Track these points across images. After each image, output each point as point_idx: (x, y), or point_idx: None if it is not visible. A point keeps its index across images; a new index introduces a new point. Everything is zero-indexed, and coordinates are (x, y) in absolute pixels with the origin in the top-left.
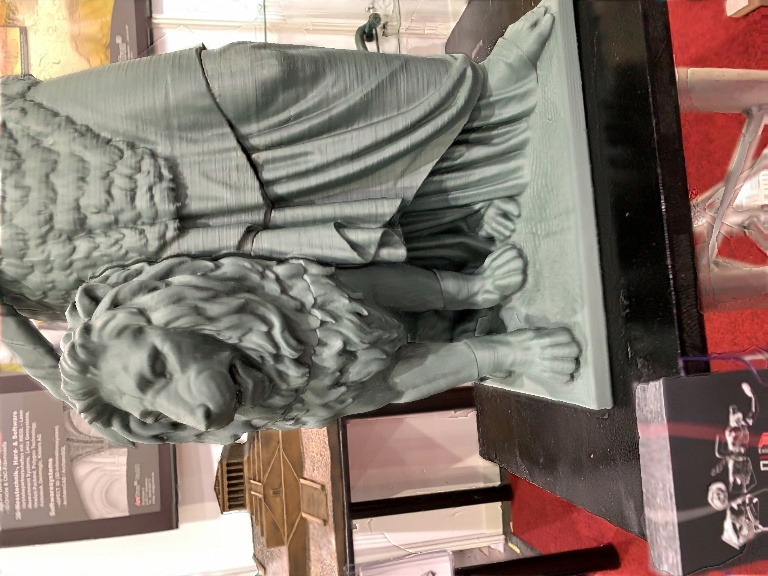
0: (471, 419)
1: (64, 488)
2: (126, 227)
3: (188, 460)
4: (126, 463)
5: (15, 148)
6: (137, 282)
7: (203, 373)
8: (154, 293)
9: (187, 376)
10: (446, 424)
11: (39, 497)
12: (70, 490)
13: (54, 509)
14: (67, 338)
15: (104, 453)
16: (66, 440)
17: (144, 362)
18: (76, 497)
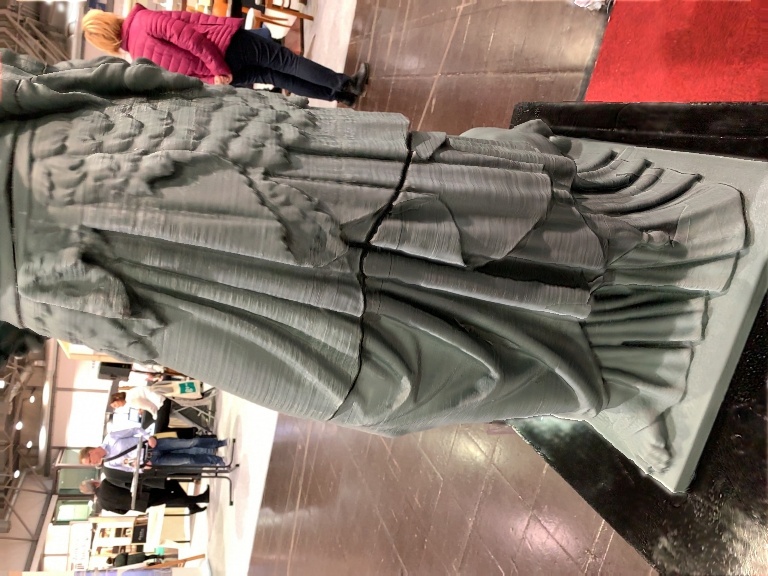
0: None
1: None
2: None
3: None
4: None
5: None
6: None
7: None
8: None
9: None
10: None
11: None
12: None
13: None
14: None
15: None
16: None
17: None
18: None
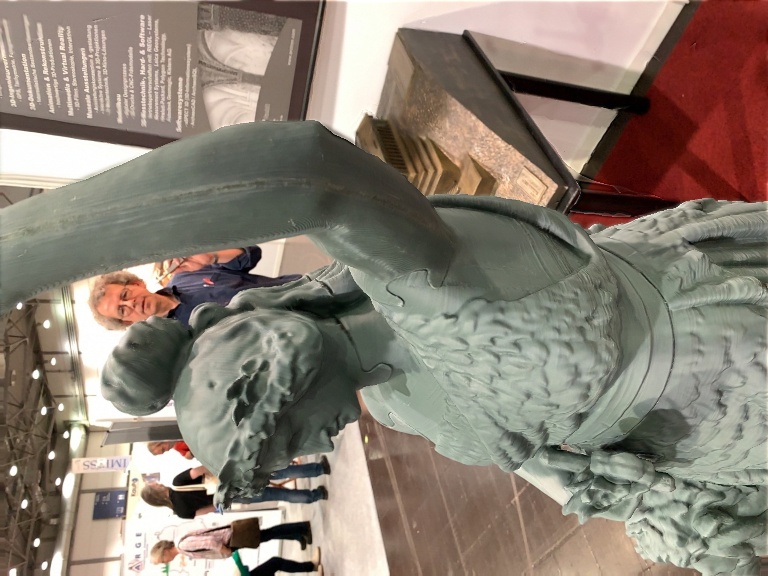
0: (581, 131)
1: (193, 110)
2: (767, 472)
3: (312, 104)
4: (257, 101)
5: (742, 424)
6: (762, 531)
7: (753, 569)
8: (767, 538)
9: (742, 569)
10: (556, 129)
11: (167, 112)
12: (200, 114)
13: (181, 126)
14: (681, 543)
15: (236, 85)
16: (198, 62)
17: (729, 570)
18: (205, 122)
